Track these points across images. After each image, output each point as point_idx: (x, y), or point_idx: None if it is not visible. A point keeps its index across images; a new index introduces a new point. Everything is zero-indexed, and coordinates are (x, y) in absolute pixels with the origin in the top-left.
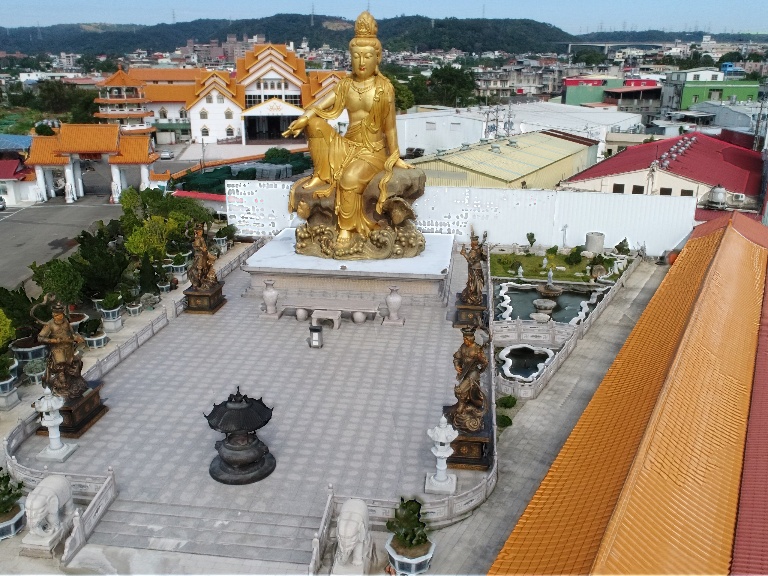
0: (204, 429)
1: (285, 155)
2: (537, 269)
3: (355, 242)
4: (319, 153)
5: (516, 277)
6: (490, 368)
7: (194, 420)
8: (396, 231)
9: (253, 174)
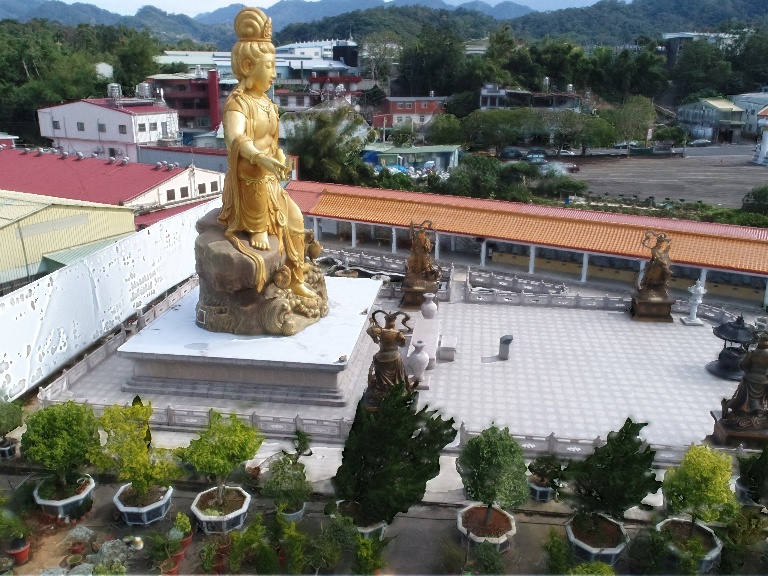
0: (698, 390)
1: None
2: None
3: None
4: None
5: None
6: (526, 302)
7: (687, 396)
8: None
9: None
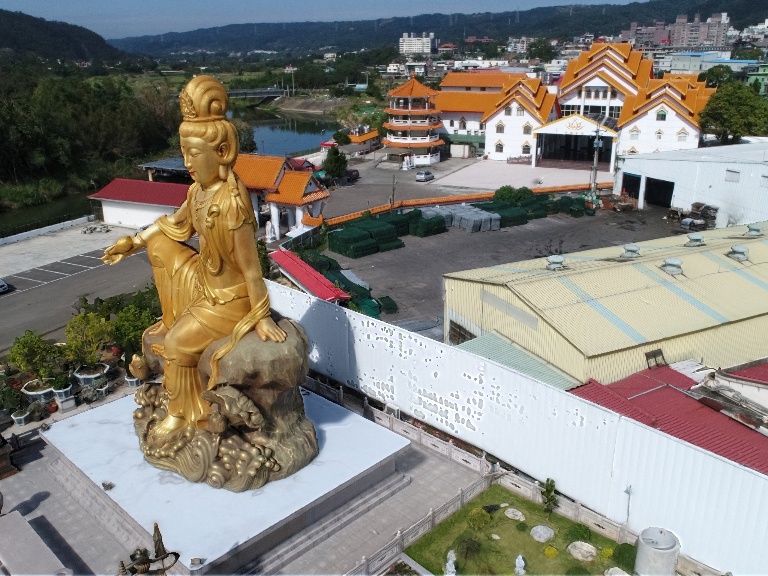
0: None
1: (522, 196)
2: (488, 575)
3: (177, 438)
4: (160, 289)
5: (440, 575)
6: None
7: None
8: (216, 443)
9: (439, 224)
